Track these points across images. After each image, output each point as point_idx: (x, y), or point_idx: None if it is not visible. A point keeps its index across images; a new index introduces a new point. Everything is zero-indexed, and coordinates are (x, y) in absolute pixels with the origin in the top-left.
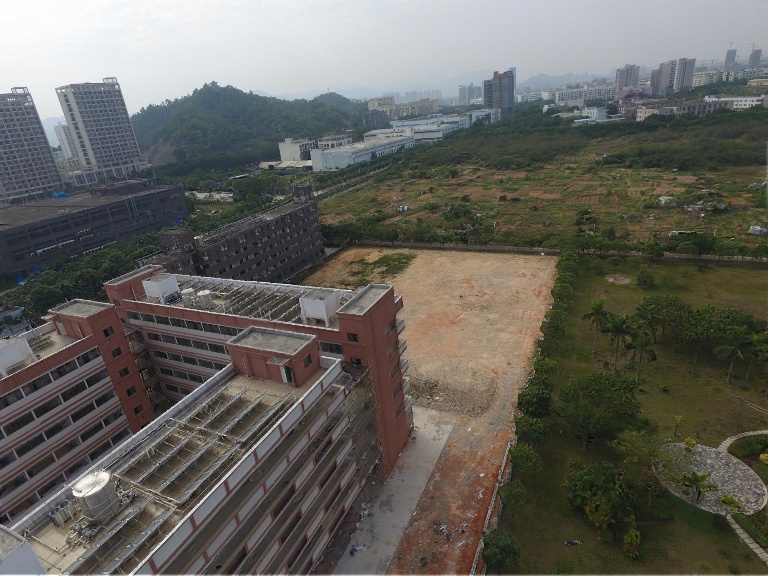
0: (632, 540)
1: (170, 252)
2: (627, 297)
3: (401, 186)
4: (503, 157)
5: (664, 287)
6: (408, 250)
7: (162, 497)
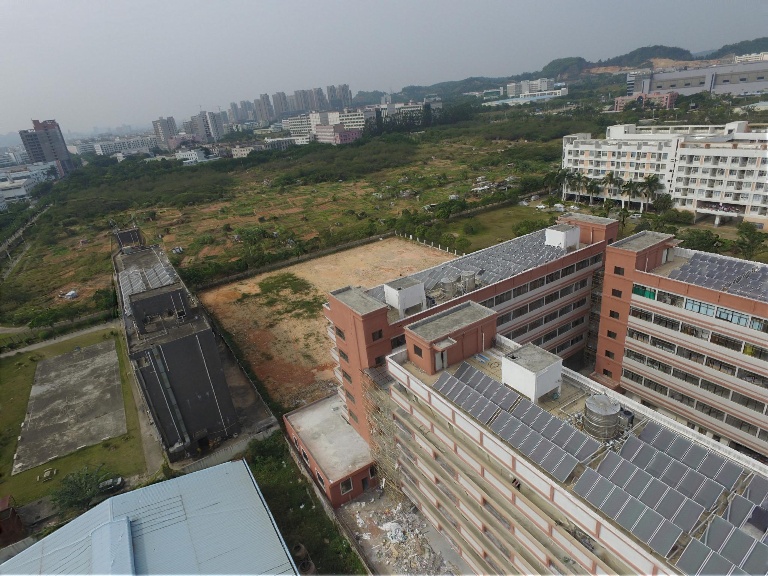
0: None
1: (146, 329)
2: (476, 240)
3: (105, 239)
4: (185, 194)
5: (478, 230)
6: (270, 273)
7: None
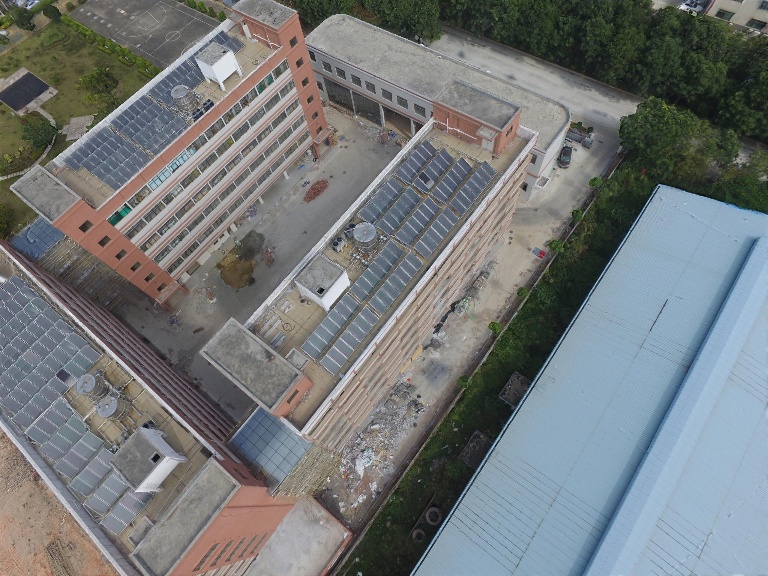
0: (0, 205)
1: None
2: None
3: None
4: None
5: None
6: None
7: (154, 98)
